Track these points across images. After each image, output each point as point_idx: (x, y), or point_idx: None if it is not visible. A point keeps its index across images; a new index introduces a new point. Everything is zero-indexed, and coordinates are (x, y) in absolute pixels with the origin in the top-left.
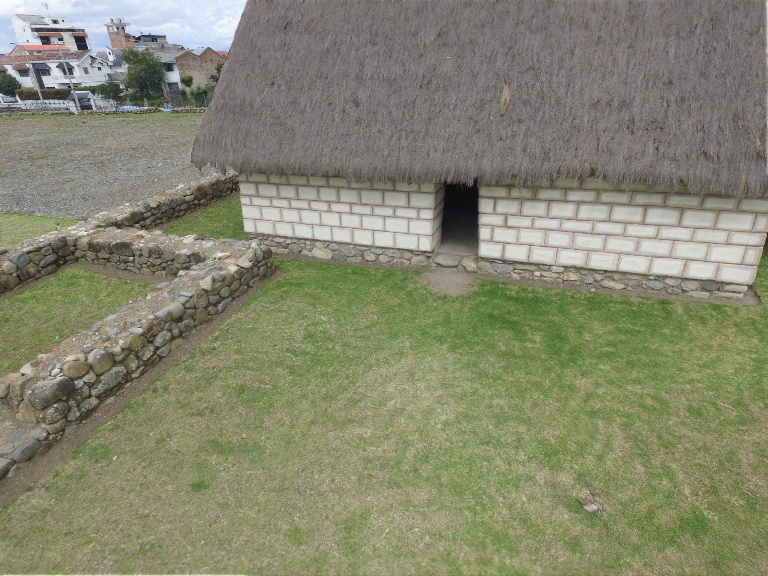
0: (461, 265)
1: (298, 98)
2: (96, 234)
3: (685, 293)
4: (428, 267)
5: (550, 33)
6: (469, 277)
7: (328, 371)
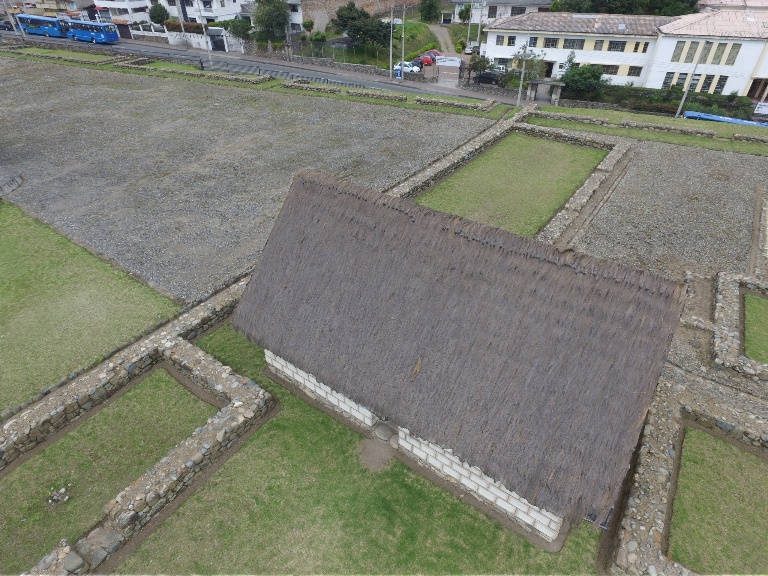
0: (389, 442)
1: (298, 307)
2: (175, 348)
3: (518, 522)
4: (370, 432)
5: (461, 325)
6: (391, 453)
7: (269, 523)
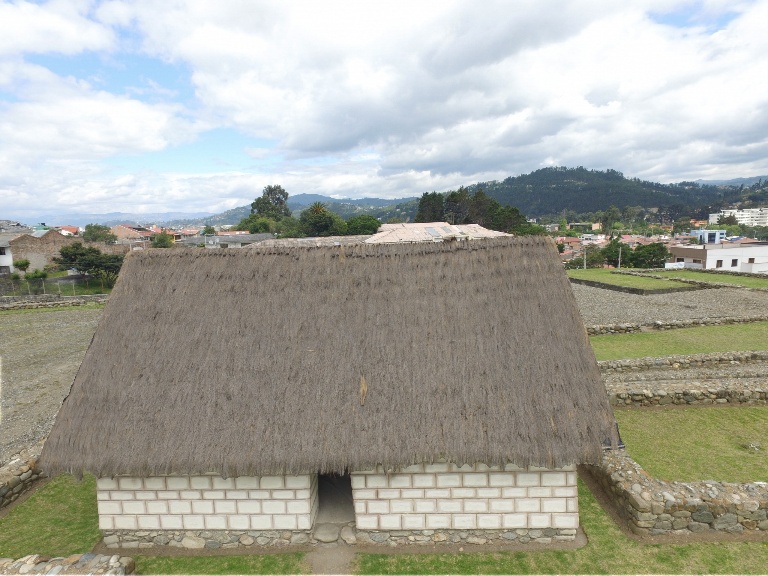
0: (341, 538)
1: (168, 391)
2: None
3: (533, 540)
4: (308, 544)
5: (391, 329)
6: (350, 552)
7: None
